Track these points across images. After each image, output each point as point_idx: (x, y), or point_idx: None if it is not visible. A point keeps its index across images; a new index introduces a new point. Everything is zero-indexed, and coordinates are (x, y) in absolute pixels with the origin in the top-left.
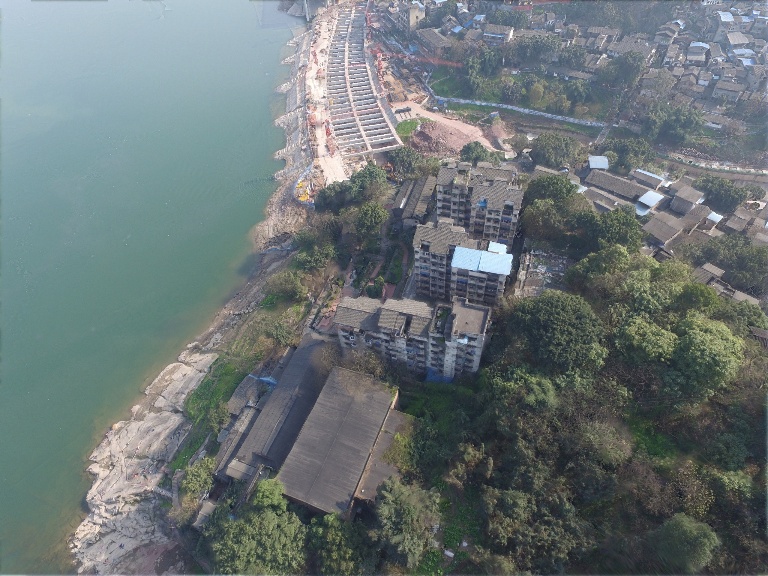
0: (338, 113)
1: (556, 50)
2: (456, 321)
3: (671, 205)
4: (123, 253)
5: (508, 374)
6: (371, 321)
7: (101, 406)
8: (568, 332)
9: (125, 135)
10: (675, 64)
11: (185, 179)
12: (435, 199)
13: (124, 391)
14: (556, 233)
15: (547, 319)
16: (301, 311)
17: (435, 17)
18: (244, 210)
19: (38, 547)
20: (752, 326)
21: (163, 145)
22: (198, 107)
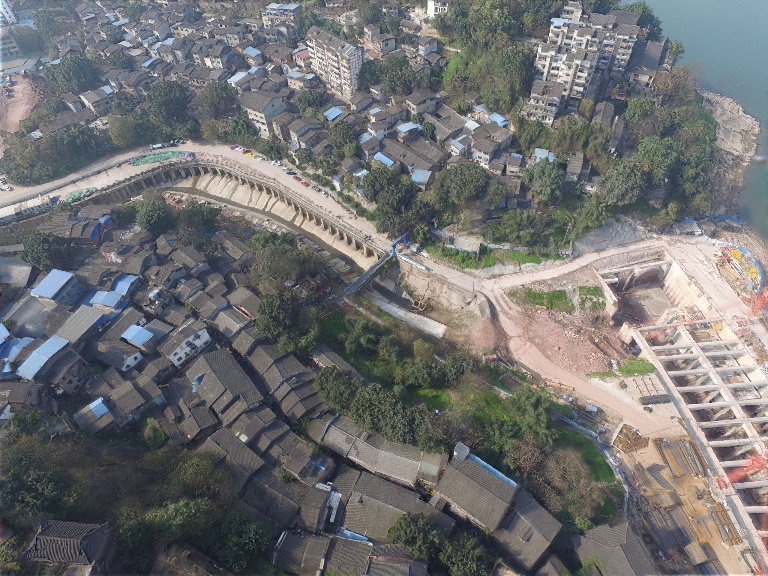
0: None
1: None
2: None
3: None
4: None
5: None
6: None
7: None
8: None
9: None
10: None
11: None
12: None
13: None
14: None
15: None
16: None
17: None
18: None
19: (750, 101)
20: None
21: None
22: None
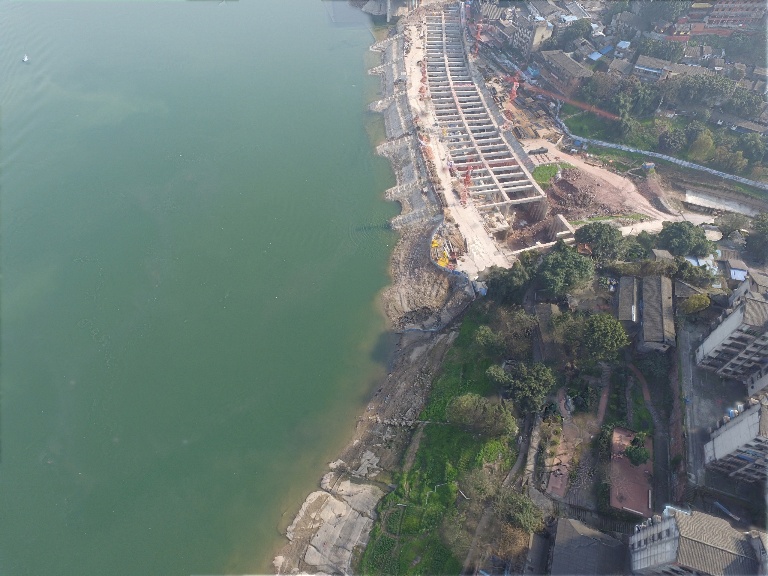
0: None
1: (727, 95)
2: None
3: None
4: (222, 318)
5: None
6: (742, 570)
7: (231, 553)
8: None
9: (199, 153)
10: None
11: (282, 219)
12: (676, 311)
13: (257, 530)
14: None
15: None
16: (508, 453)
17: (561, 37)
18: (363, 268)
19: None
20: None
21: (247, 170)
22: (281, 122)
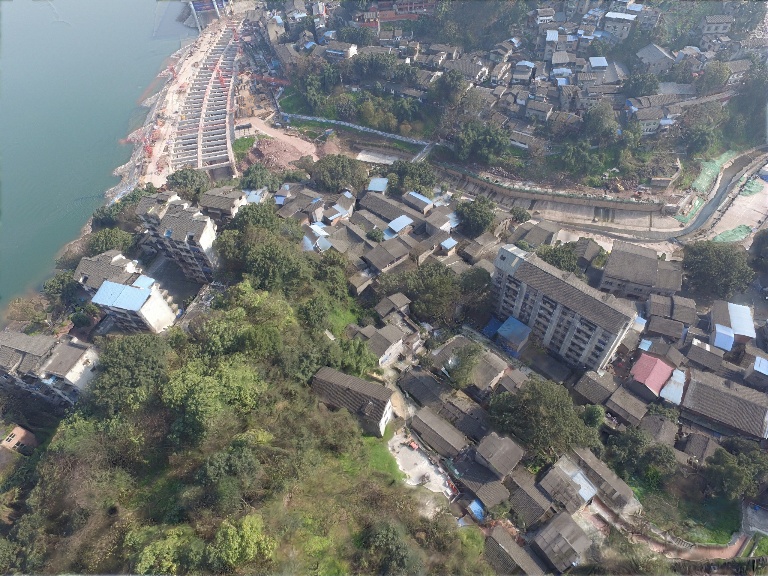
0: (190, 128)
1: (389, 68)
2: (49, 360)
3: (426, 229)
4: None
5: (71, 416)
6: None
7: None
8: (118, 375)
9: None
10: (501, 83)
11: (18, 196)
12: None
13: None
14: (237, 264)
15: (106, 361)
16: None
17: (296, 32)
18: (63, 228)
19: None
20: (327, 366)
21: (10, 160)
22: (59, 121)
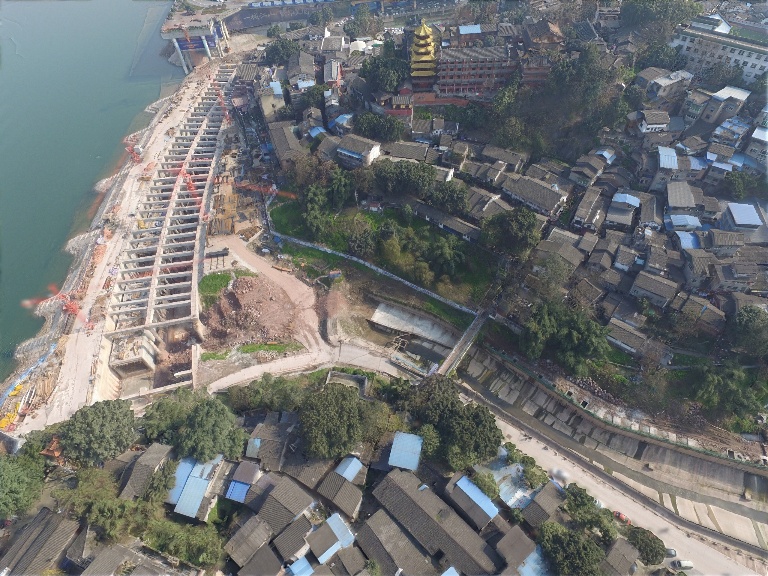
0: None
1: (425, 188)
2: None
3: None
4: None
5: None
6: None
7: None
8: None
9: None
10: (588, 226)
11: None
12: None
13: None
14: None
15: None
16: None
17: (300, 105)
18: None
19: None
20: None
21: None
22: None
